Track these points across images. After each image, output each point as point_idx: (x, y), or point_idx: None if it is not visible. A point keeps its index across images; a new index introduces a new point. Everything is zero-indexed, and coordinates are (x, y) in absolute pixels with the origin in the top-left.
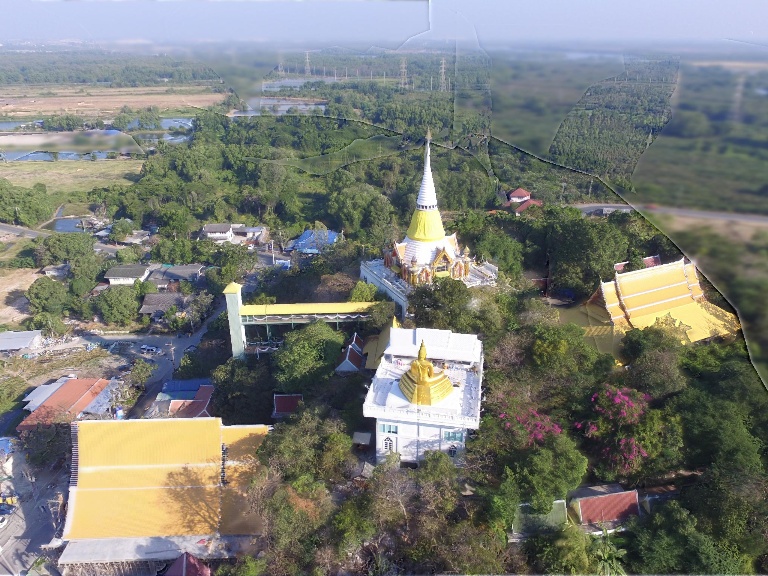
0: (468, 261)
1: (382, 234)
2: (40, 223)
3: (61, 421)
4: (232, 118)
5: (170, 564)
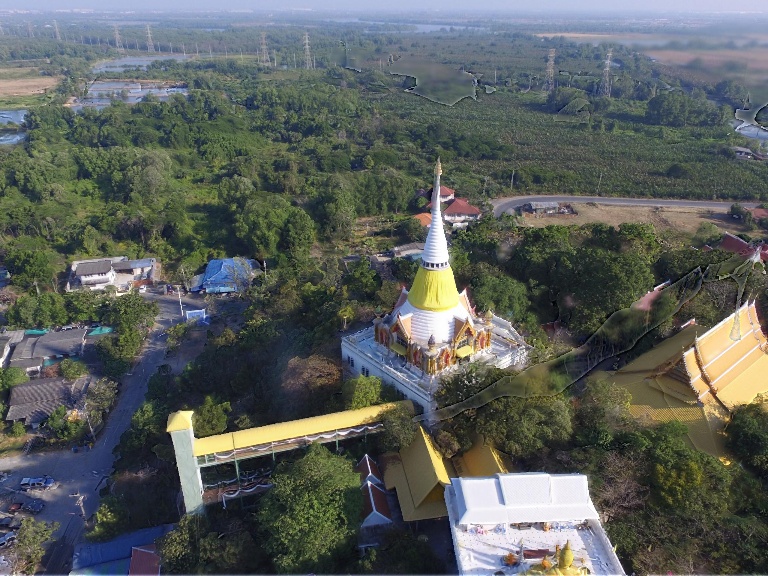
0: (492, 328)
1: (306, 257)
2: None
3: None
4: (75, 110)
5: None
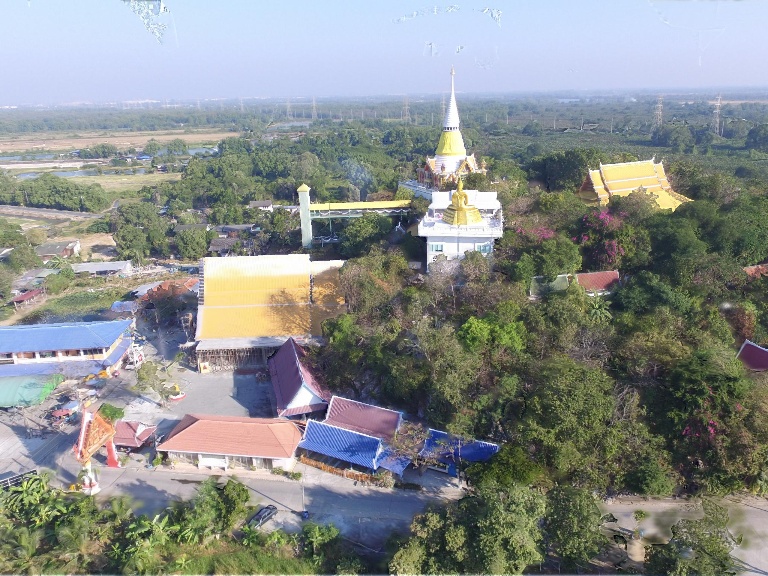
0: (485, 171)
1: None
2: (102, 210)
3: (176, 284)
4: (253, 143)
5: (278, 349)
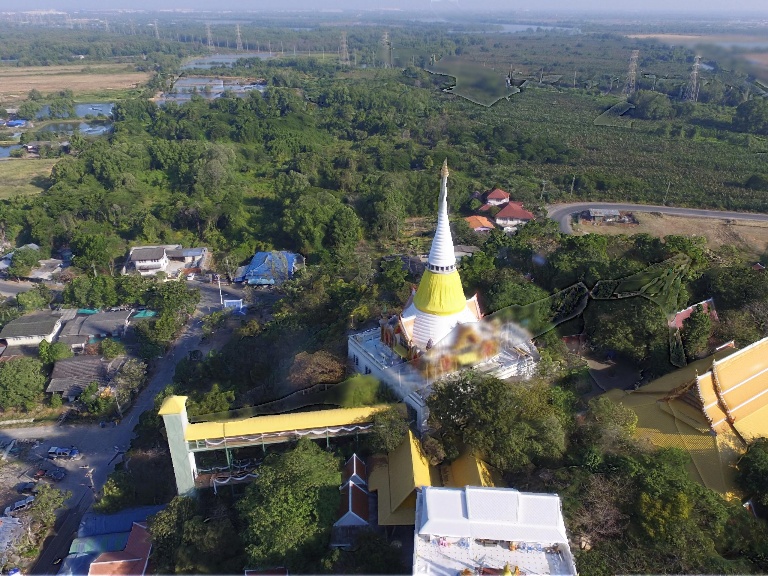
0: None
1: (349, 254)
2: None
3: None
4: (159, 104)
5: None
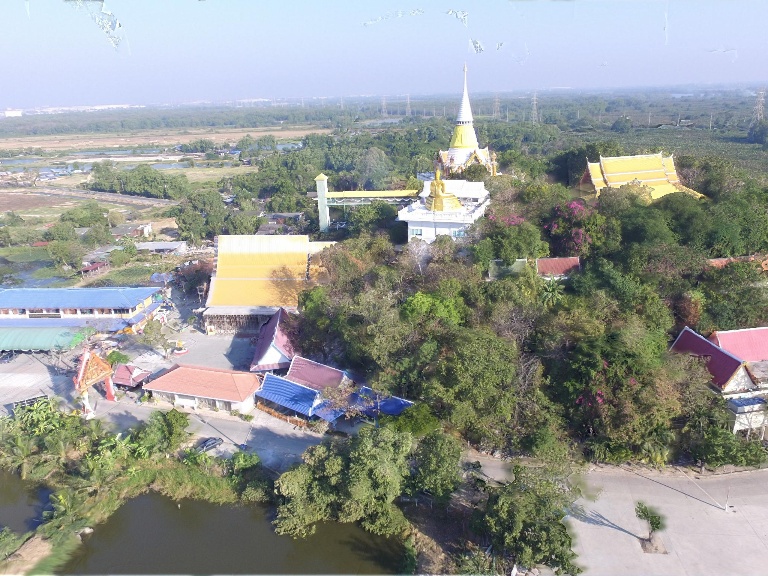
0: (495, 164)
1: None
2: (182, 198)
3: (204, 260)
4: (336, 139)
5: None
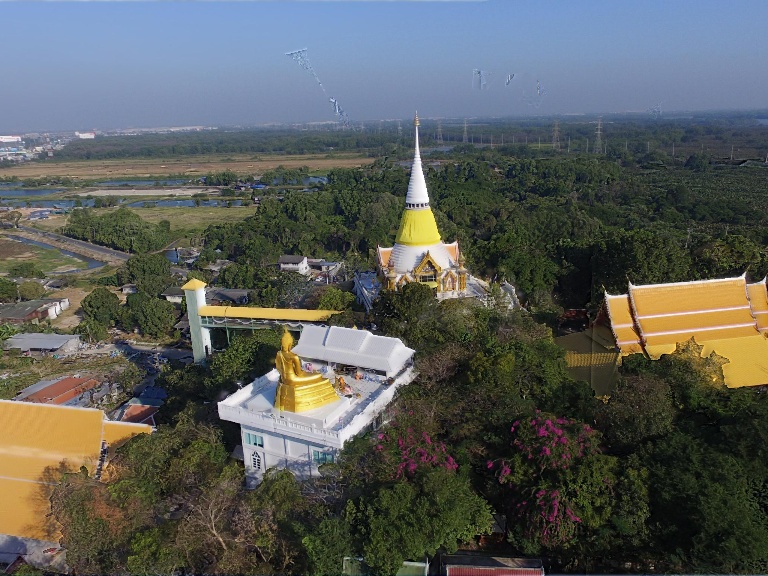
0: (462, 271)
1: None
2: (150, 252)
3: None
4: (366, 174)
5: None
